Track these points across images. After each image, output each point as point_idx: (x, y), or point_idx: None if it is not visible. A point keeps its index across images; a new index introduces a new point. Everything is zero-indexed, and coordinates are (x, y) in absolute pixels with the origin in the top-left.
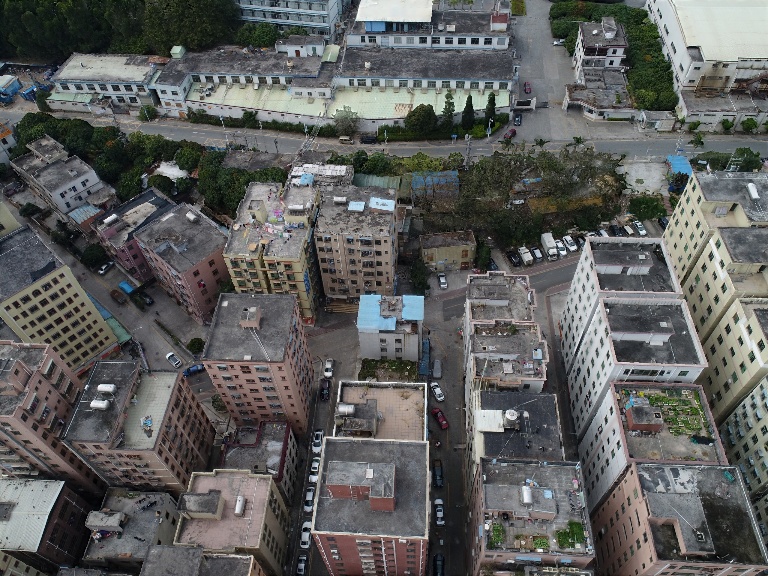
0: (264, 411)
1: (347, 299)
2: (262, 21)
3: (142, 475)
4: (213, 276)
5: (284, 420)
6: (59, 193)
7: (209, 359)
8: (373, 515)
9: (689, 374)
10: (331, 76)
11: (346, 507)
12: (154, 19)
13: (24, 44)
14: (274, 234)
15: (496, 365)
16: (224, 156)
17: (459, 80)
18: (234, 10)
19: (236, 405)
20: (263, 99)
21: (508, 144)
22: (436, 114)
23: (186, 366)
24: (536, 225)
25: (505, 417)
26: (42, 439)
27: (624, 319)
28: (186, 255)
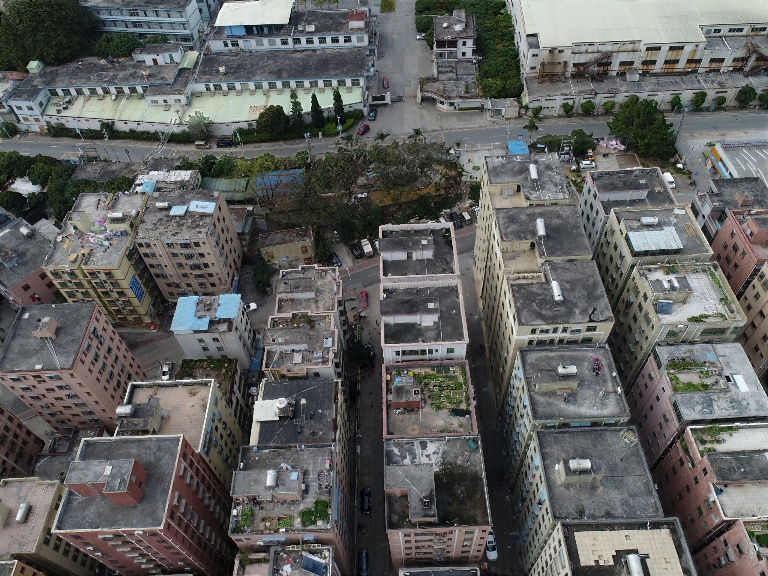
0: (80, 419)
1: None
2: (125, 31)
3: None
4: (48, 289)
5: (103, 426)
6: None
7: None
8: (118, 510)
9: (456, 351)
10: (186, 82)
11: (93, 505)
12: (9, 35)
13: None
14: (97, 243)
15: (287, 356)
16: (75, 168)
17: (311, 79)
18: (93, 22)
19: (49, 415)
20: (120, 109)
21: (349, 140)
22: (289, 114)
23: None
24: (376, 217)
25: (276, 405)
26: None
27: (395, 303)
28: (16, 270)
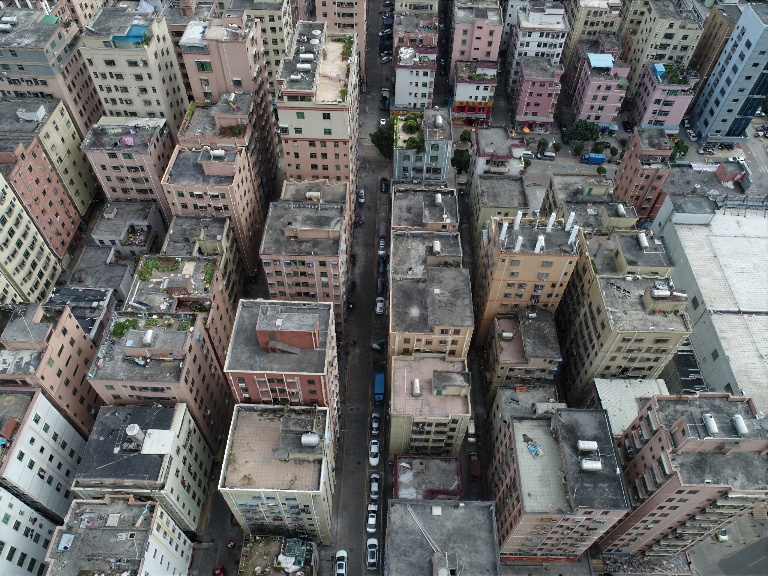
0: None
1: None
2: None
3: None
4: None
5: None
6: None
7: (483, 502)
8: None
9: None
10: None
11: None
12: None
13: None
14: None
15: None
16: None
17: None
18: None
19: None
20: None
21: None
22: None
23: None
24: None
25: None
26: None
27: None
28: None
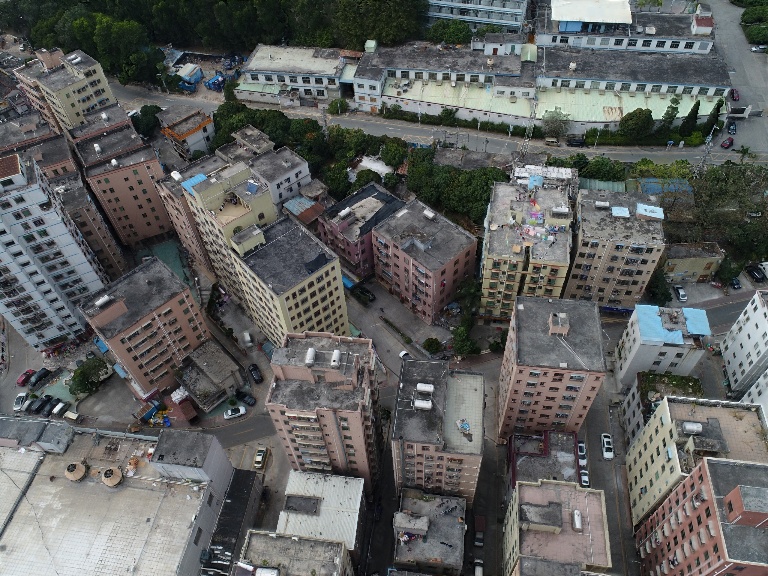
0: (544, 420)
1: None
2: (449, 18)
3: (442, 478)
4: (453, 276)
5: (561, 430)
6: (276, 183)
7: (526, 364)
8: None
9: None
10: (535, 76)
11: (751, 535)
12: (348, 12)
13: (210, 34)
14: (534, 236)
15: None
16: (434, 153)
17: (672, 84)
18: (425, 6)
19: (518, 412)
20: (462, 97)
21: (745, 153)
22: None
23: None
24: None
25: None
26: (363, 436)
27: None
28: (431, 253)
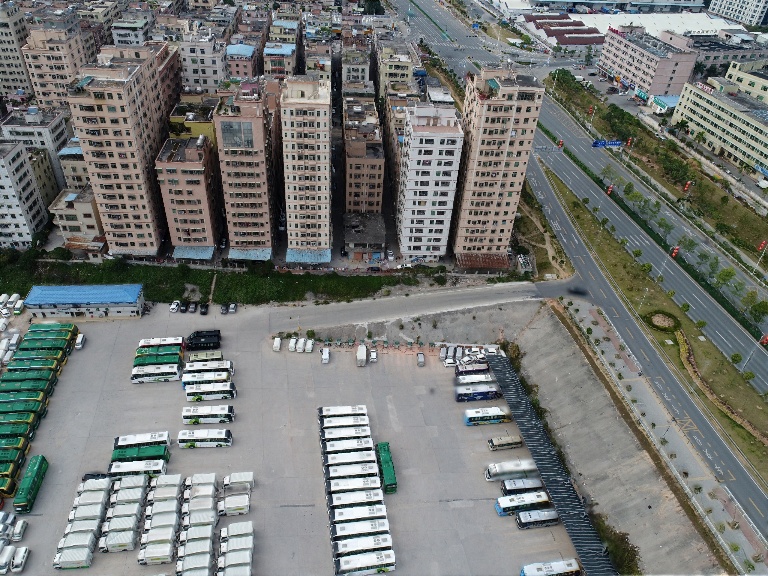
0: None
1: None
2: None
3: None
4: None
5: None
6: None
7: None
8: None
9: None
10: None
11: None
12: None
13: None
14: None
15: None
16: None
17: None
18: None
19: None
20: None
21: None
22: None
23: None
24: None
25: (32, 1)
26: None
27: None
28: None
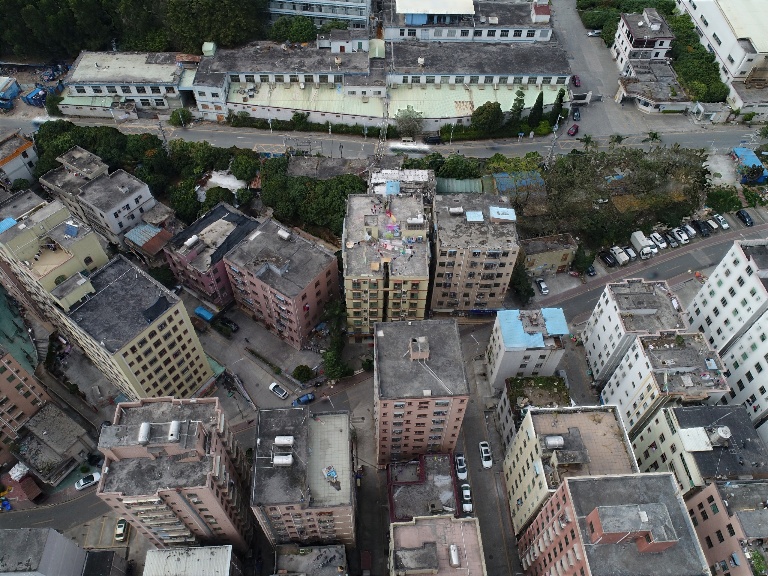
0: (419, 443)
1: (451, 312)
2: (292, 14)
3: (317, 529)
4: (316, 298)
5: (437, 450)
6: (113, 213)
7: (389, 398)
8: (644, 558)
9: None
10: (384, 73)
11: (613, 553)
12: (179, 13)
13: (21, 41)
14: (392, 251)
15: (674, 379)
16: (287, 163)
17: (518, 75)
18: (264, 2)
19: (392, 440)
20: (313, 99)
21: (588, 142)
22: None
23: (293, 396)
24: (627, 224)
25: (717, 436)
26: (221, 505)
27: None
28: (289, 277)
